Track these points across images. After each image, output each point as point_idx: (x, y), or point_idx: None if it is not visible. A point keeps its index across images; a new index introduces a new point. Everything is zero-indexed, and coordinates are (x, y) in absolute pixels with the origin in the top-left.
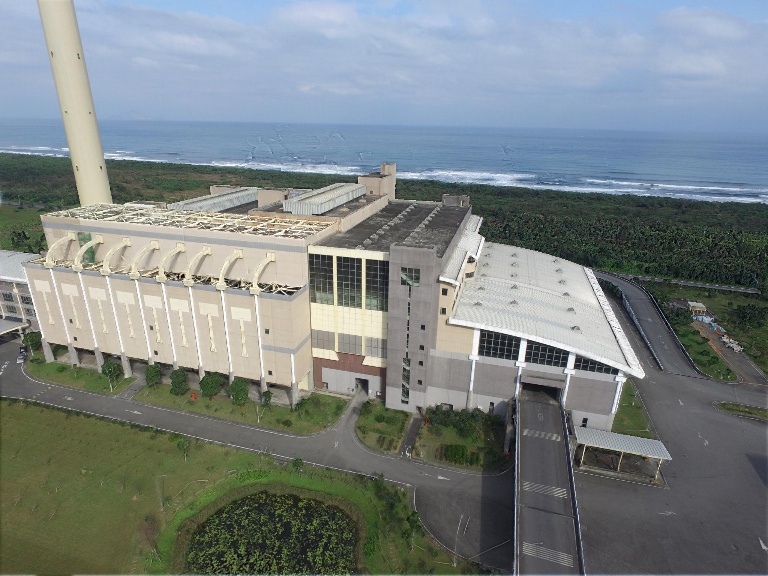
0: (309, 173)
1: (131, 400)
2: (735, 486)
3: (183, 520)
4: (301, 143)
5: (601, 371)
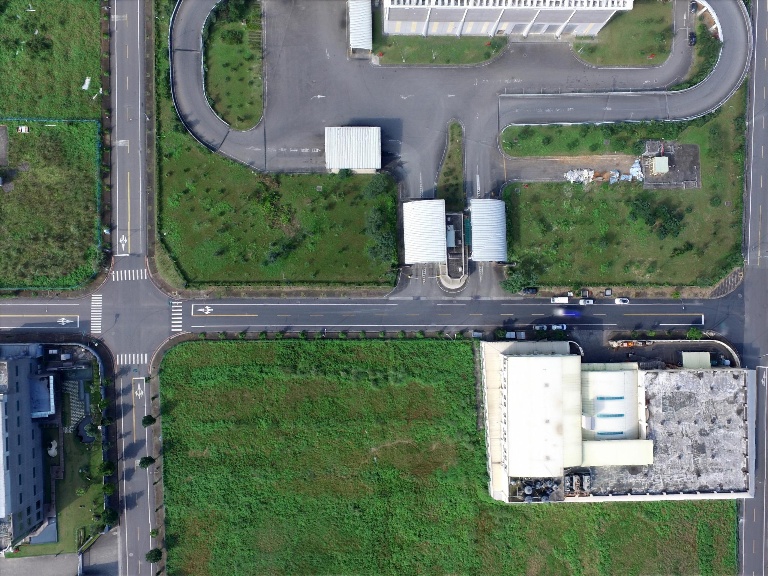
0: None
1: None
2: (364, 99)
3: None
4: None
5: None
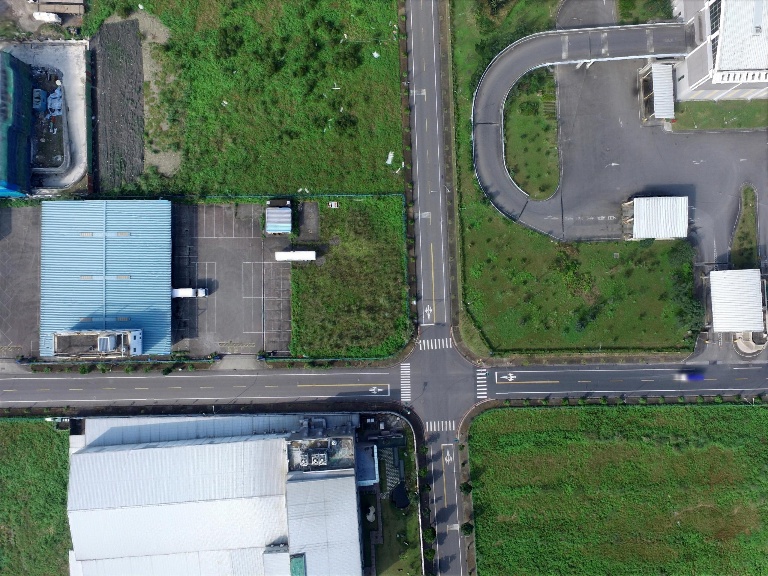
0: None
1: None
2: (657, 166)
3: None
4: None
5: (714, 58)
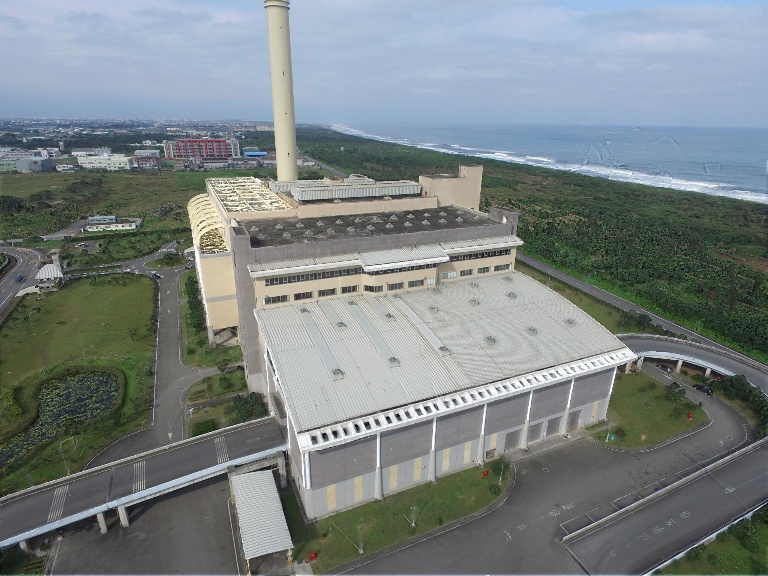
0: (636, 184)
1: (180, 304)
2: None
3: (80, 365)
4: (638, 149)
5: None
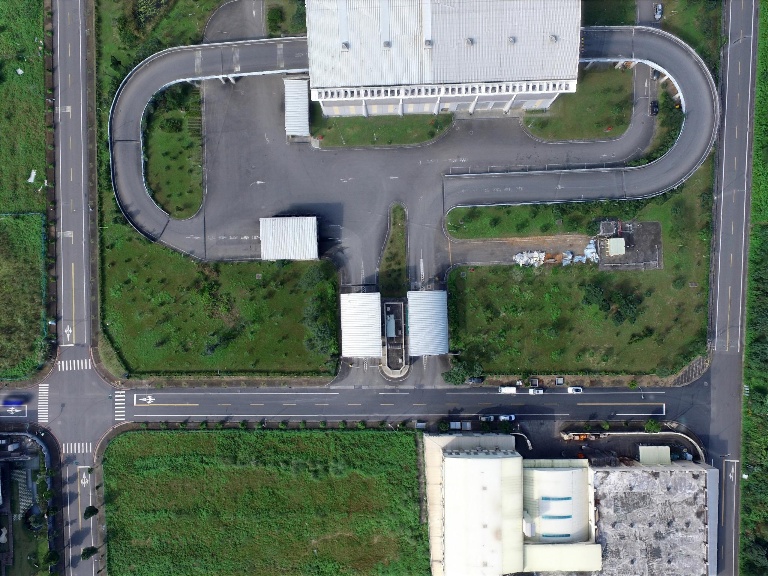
0: None
1: None
2: (303, 184)
3: None
4: None
5: None
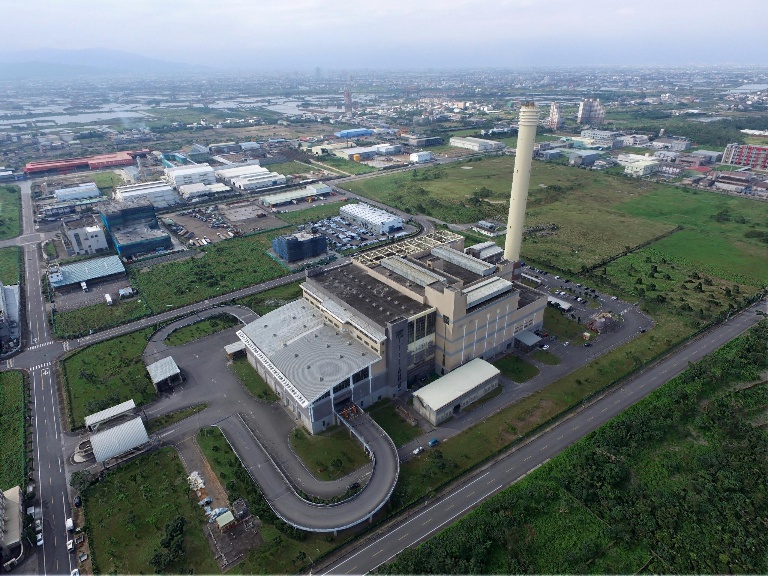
0: None
1: None
2: None
3: None
4: None
5: None
